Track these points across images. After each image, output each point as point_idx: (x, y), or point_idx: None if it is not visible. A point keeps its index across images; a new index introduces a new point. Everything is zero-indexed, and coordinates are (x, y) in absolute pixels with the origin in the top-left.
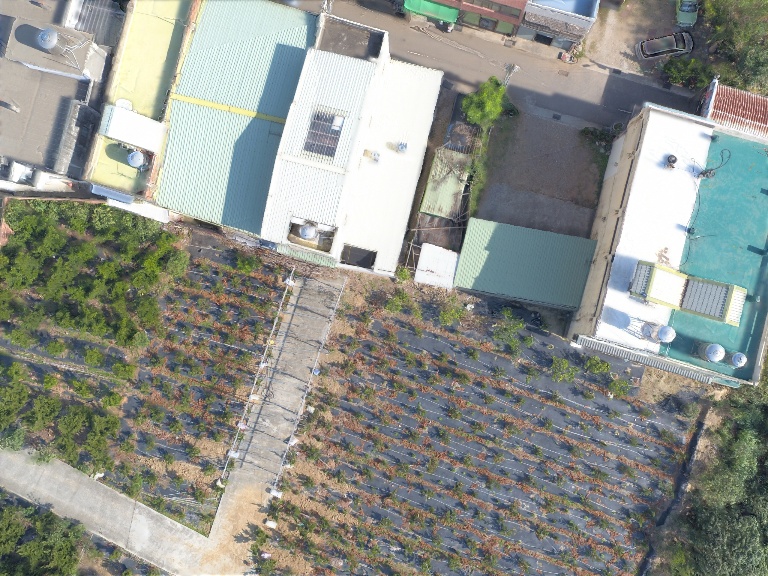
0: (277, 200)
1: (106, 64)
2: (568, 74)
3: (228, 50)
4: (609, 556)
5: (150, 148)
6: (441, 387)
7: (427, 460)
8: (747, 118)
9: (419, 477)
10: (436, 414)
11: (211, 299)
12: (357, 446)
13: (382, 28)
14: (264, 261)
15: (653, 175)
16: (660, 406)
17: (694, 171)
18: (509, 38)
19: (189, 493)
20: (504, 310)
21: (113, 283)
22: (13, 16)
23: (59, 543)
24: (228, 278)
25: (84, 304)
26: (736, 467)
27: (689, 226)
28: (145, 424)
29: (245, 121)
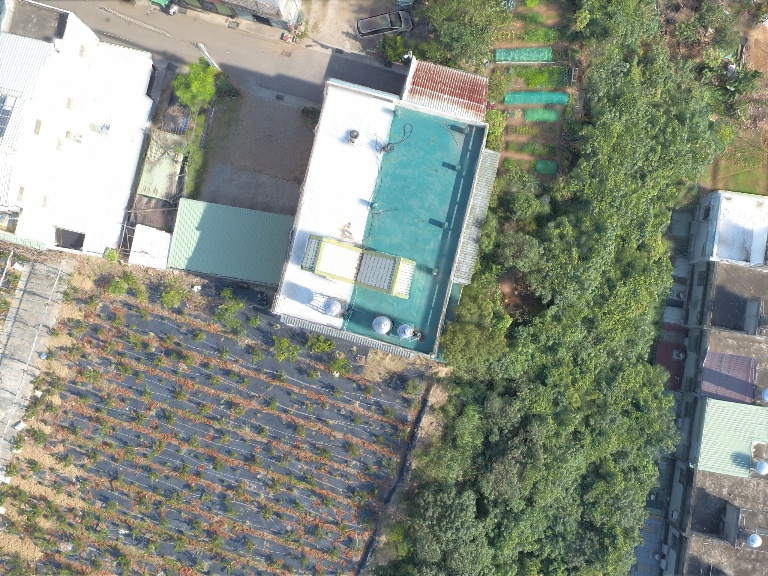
0: None
1: None
2: (291, 54)
3: None
4: (336, 535)
5: None
6: (168, 369)
7: (155, 442)
8: (445, 93)
9: (147, 459)
10: (163, 396)
11: None
12: (85, 430)
13: (107, 12)
14: None
15: (336, 150)
16: (386, 384)
17: (377, 146)
18: (233, 20)
19: None
20: (224, 290)
21: None
22: None
23: None
24: None
25: None
26: (458, 443)
27: (372, 201)
28: None
29: None
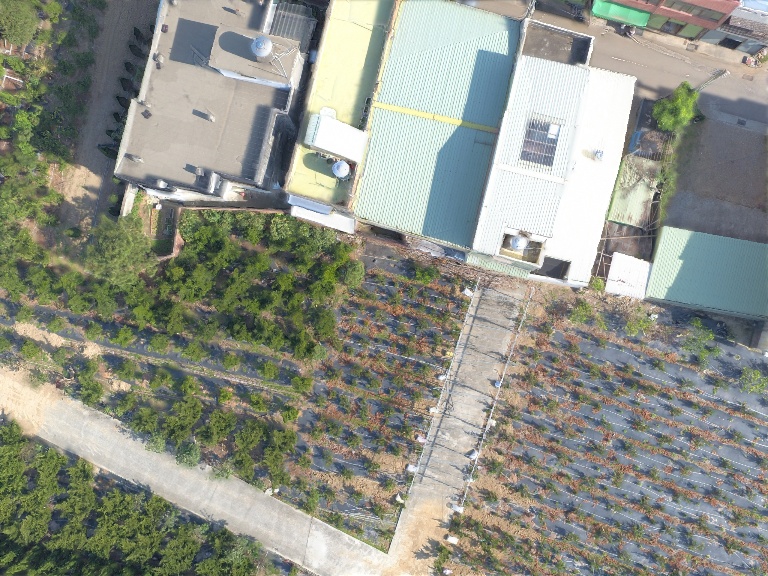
0: (492, 211)
1: (303, 71)
2: (753, 78)
3: (429, 56)
4: None
5: (353, 158)
6: (625, 399)
7: (612, 474)
8: None
9: (604, 491)
10: (621, 427)
11: (387, 310)
12: (540, 460)
13: None
14: (441, 271)
15: None
16: None
17: None
18: (691, 42)
19: (367, 508)
20: (693, 320)
21: (288, 294)
22: (205, 23)
23: (237, 560)
24: (404, 289)
25: (260, 316)
26: None
27: None
28: (321, 438)
29: (450, 129)
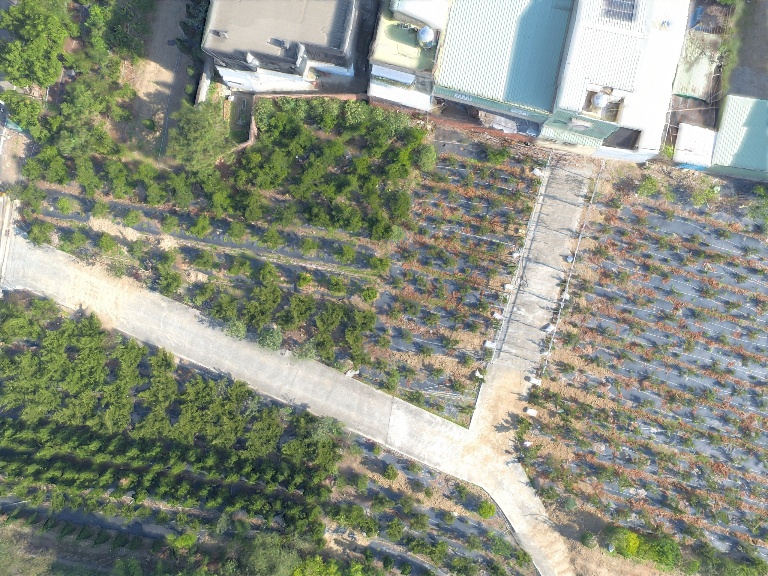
0: (574, 67)
1: None
2: None
3: None
4: None
5: (435, 25)
6: (693, 269)
7: (683, 341)
8: None
9: (676, 359)
10: (689, 296)
11: (458, 192)
12: (613, 331)
13: None
14: (510, 153)
15: None
16: None
17: None
18: None
19: (447, 386)
20: (756, 189)
21: (363, 179)
22: None
23: (323, 440)
24: (475, 171)
25: None
26: None
27: None
28: (398, 319)
29: None
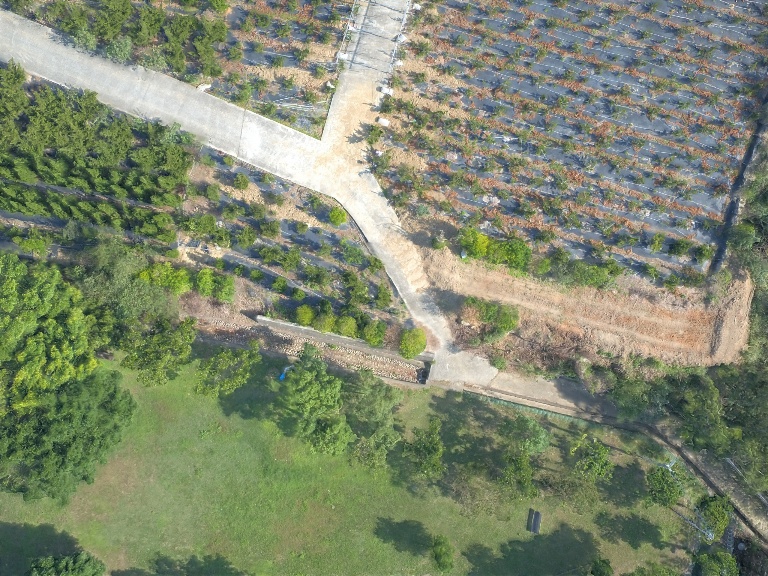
0: None
1: None
2: None
3: None
4: (719, 134)
5: None
6: None
7: (535, 51)
8: None
9: (528, 68)
10: (541, 6)
11: None
12: (465, 42)
13: None
14: None
15: None
16: None
17: None
18: None
19: (299, 97)
20: None
21: None
22: None
23: (171, 147)
24: None
25: None
26: None
27: None
28: (250, 33)
29: None
